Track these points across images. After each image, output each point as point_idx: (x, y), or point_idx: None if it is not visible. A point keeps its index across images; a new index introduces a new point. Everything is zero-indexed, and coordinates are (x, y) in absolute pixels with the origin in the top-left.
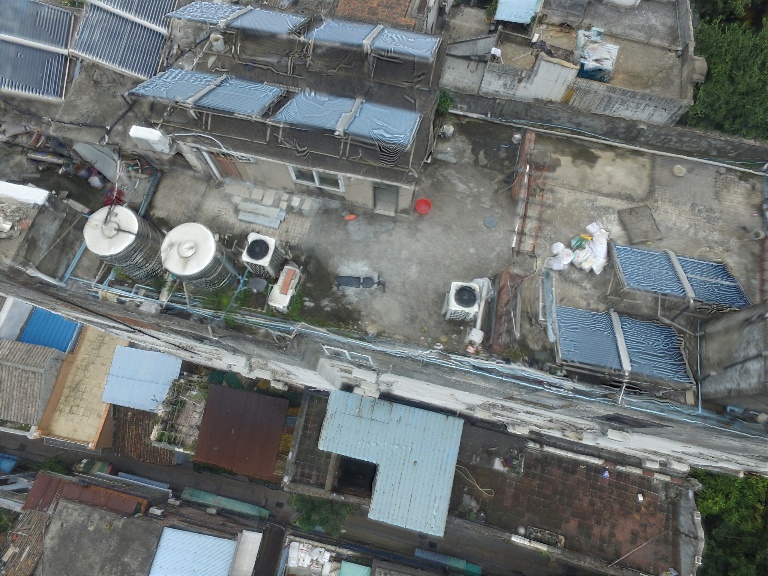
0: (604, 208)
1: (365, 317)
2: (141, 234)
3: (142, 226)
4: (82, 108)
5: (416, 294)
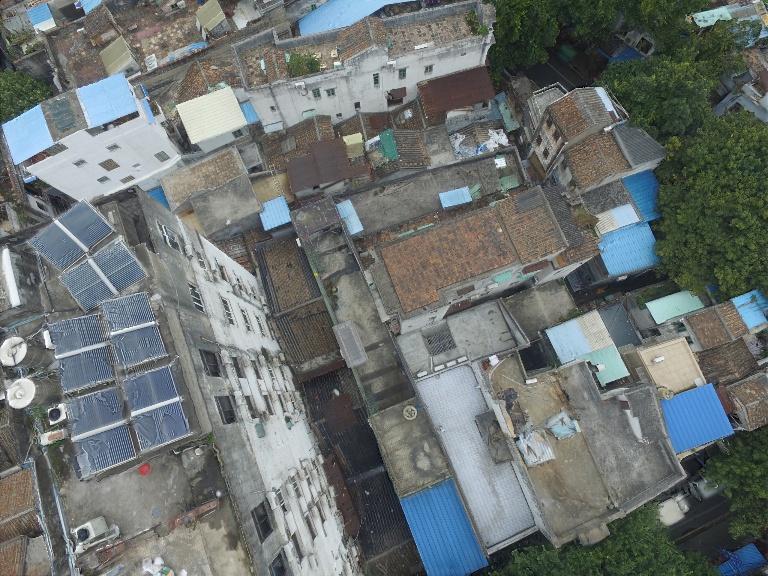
0: (203, 572)
1: (69, 483)
2: None
3: (25, 361)
4: (58, 289)
5: (95, 500)
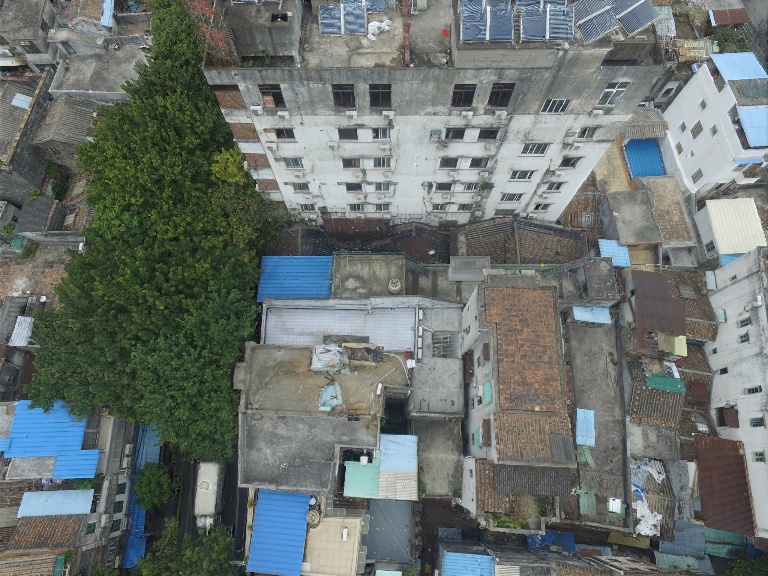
0: (369, 48)
1: None
2: None
3: None
4: None
5: (438, 7)
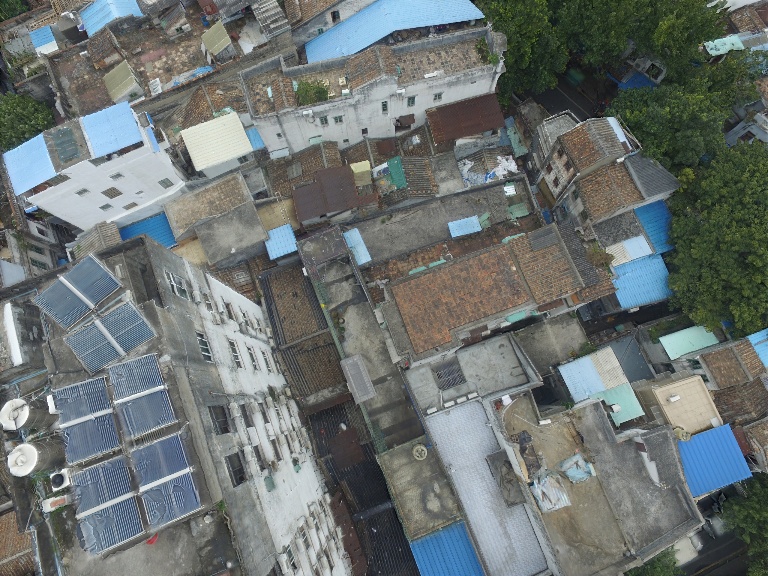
0: None
1: (72, 551)
2: (21, 428)
3: (26, 425)
4: (62, 348)
5: (99, 570)
